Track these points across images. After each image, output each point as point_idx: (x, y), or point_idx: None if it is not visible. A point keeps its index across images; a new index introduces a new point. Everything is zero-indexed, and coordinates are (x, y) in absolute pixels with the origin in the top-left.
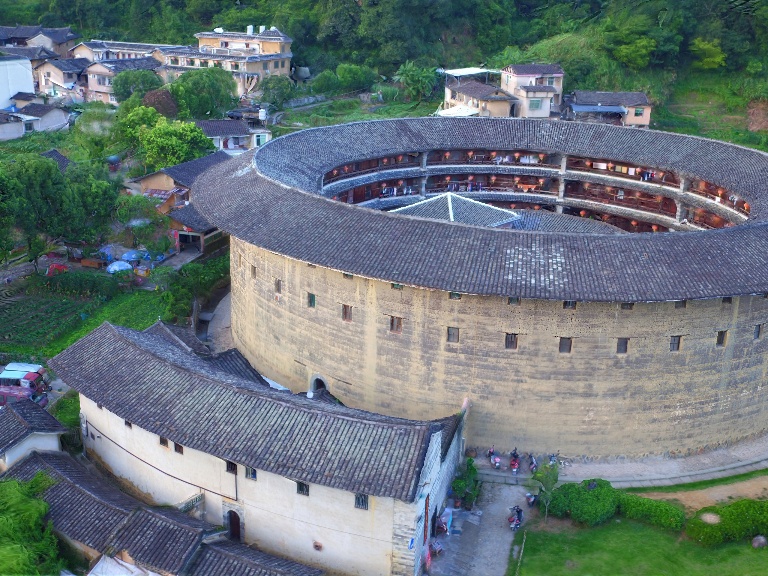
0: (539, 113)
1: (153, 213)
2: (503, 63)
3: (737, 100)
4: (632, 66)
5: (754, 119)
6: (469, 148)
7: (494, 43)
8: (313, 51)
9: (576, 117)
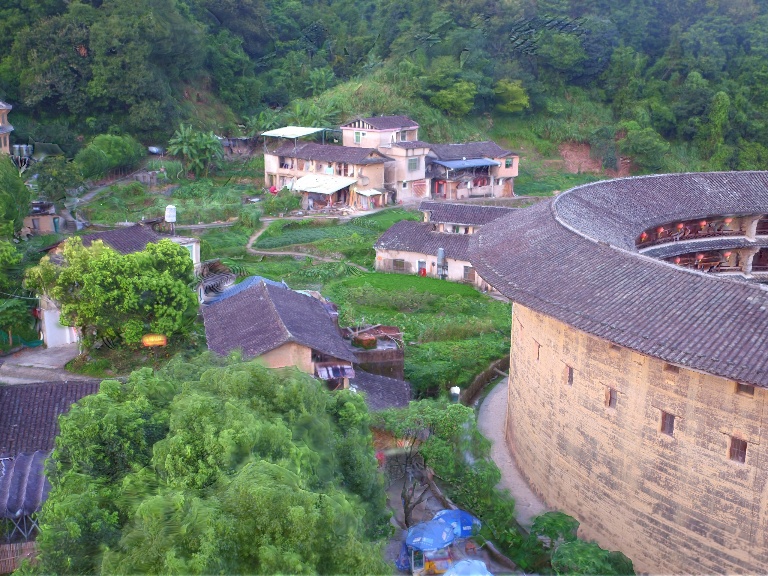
0: (417, 175)
1: (479, 436)
2: (296, 120)
3: (547, 143)
4: (455, 113)
5: (571, 161)
6: (668, 222)
7: (243, 99)
8: (20, 121)
9: (449, 175)
